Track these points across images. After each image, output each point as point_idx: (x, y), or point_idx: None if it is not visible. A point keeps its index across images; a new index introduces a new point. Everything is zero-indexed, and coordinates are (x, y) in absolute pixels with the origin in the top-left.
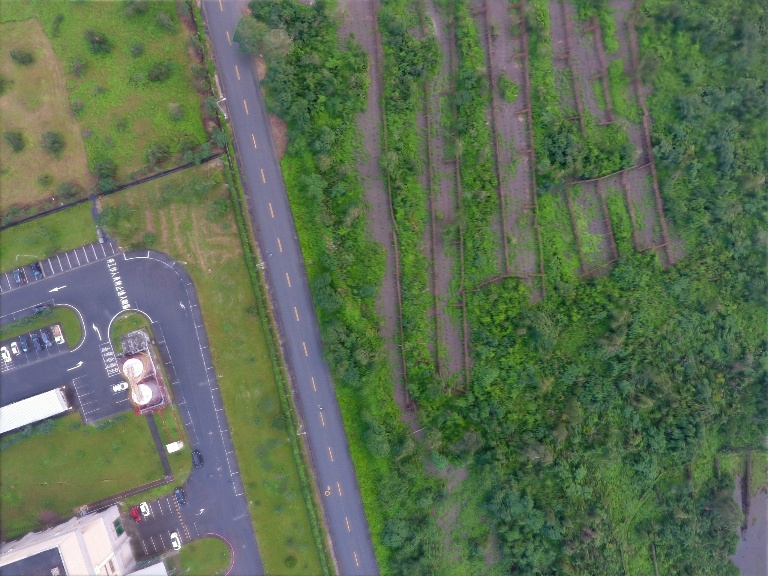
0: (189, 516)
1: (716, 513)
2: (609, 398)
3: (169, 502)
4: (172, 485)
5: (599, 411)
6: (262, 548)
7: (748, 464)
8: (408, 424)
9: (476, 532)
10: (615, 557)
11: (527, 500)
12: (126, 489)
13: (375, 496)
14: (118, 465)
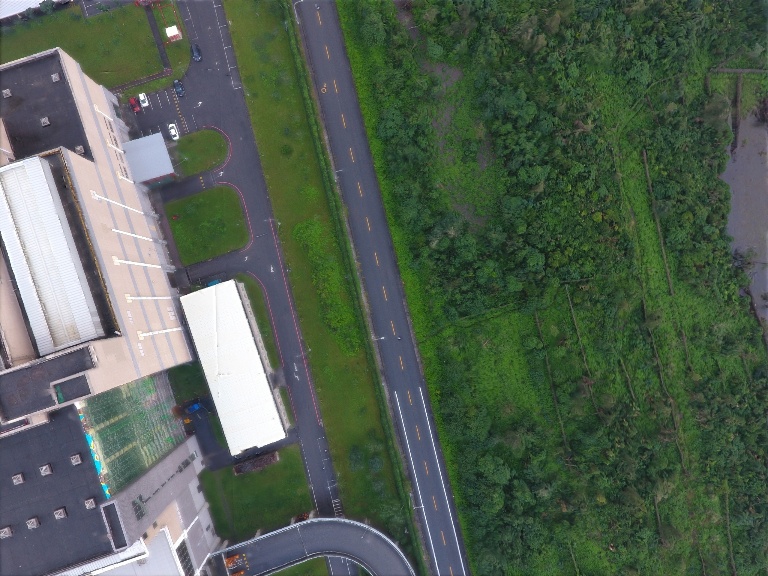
0: (187, 108)
1: (706, 127)
2: (602, 6)
3: (168, 95)
4: (171, 78)
5: (592, 21)
6: (259, 140)
7: (738, 85)
8: (404, 23)
9: (470, 133)
10: (607, 156)
11: (520, 91)
12: (125, 82)
13: (371, 91)
14: (118, 57)
